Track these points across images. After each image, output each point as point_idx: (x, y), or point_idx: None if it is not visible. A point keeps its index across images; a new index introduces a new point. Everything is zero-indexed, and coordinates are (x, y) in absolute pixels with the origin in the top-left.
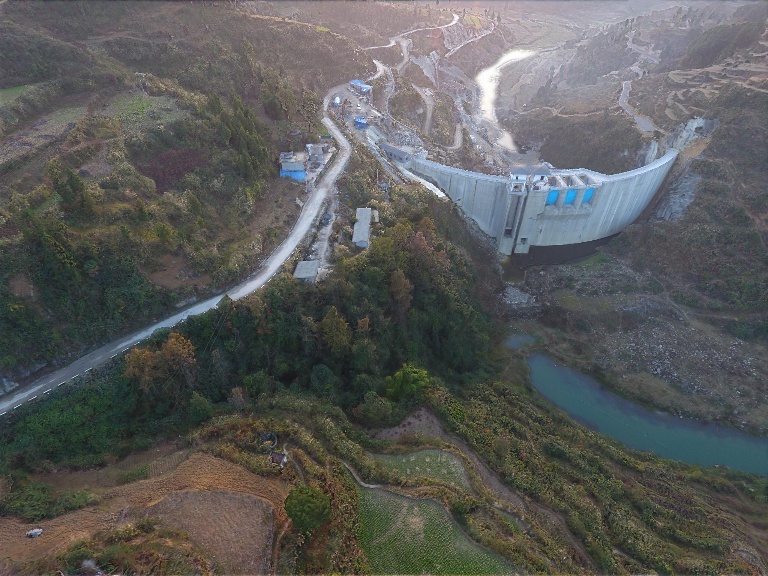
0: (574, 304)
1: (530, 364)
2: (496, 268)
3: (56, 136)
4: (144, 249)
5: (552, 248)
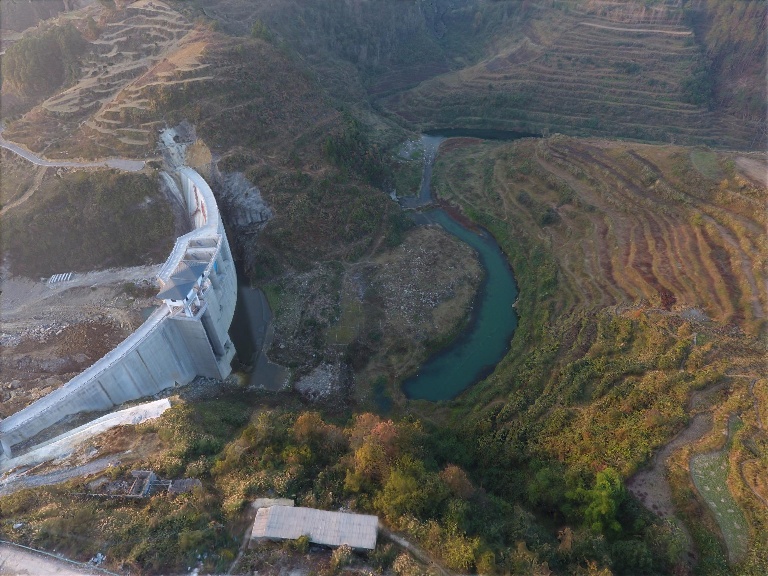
0: (348, 332)
1: (414, 397)
2: (260, 390)
3: None
4: None
5: (232, 326)
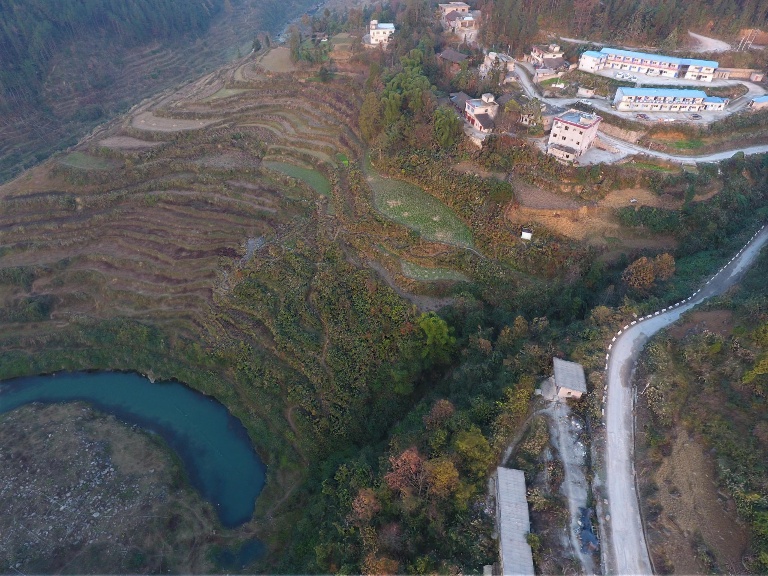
0: None
1: (250, 512)
2: None
3: None
4: (761, 313)
5: None
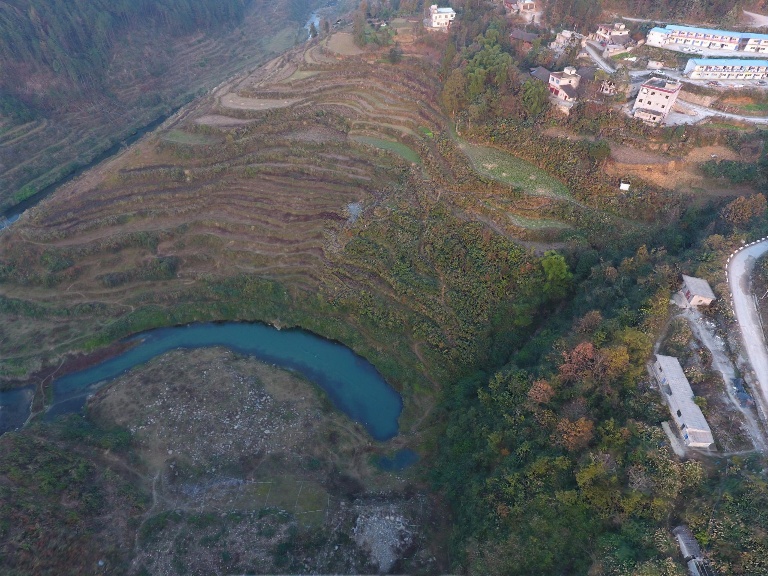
0: (308, 495)
1: (395, 429)
2: None
3: None
4: None
5: None
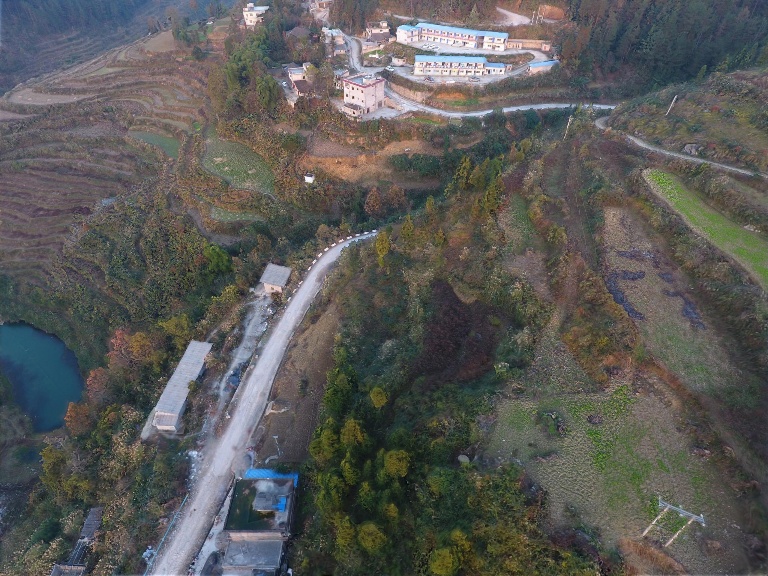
0: None
1: (62, 421)
2: None
3: (615, 276)
4: None
5: None
